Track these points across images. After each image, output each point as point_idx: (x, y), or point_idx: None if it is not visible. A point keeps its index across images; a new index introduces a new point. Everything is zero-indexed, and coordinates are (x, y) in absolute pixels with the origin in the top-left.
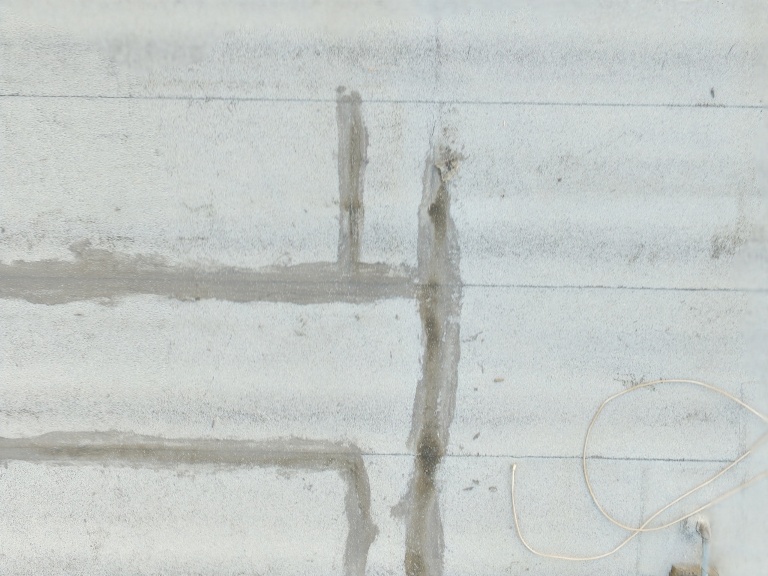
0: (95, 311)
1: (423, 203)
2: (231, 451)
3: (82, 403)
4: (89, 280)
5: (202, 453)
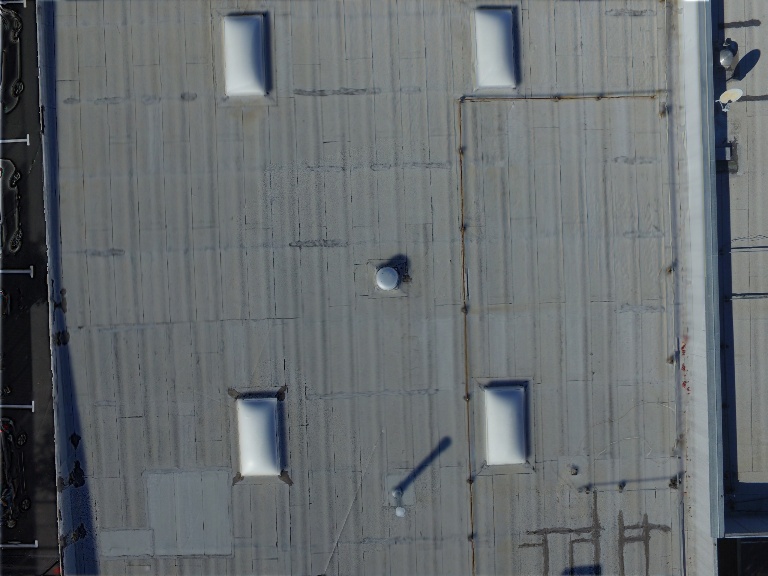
0: None
1: (534, 535)
2: (571, 560)
3: None
4: None
5: (572, 565)
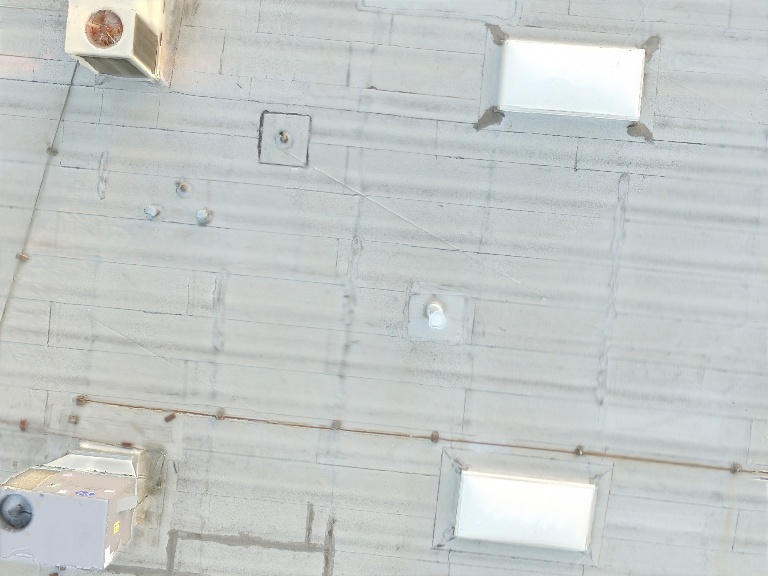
0: (243, 549)
1: (327, 530)
2: None
3: (237, 570)
4: (242, 541)
5: None
